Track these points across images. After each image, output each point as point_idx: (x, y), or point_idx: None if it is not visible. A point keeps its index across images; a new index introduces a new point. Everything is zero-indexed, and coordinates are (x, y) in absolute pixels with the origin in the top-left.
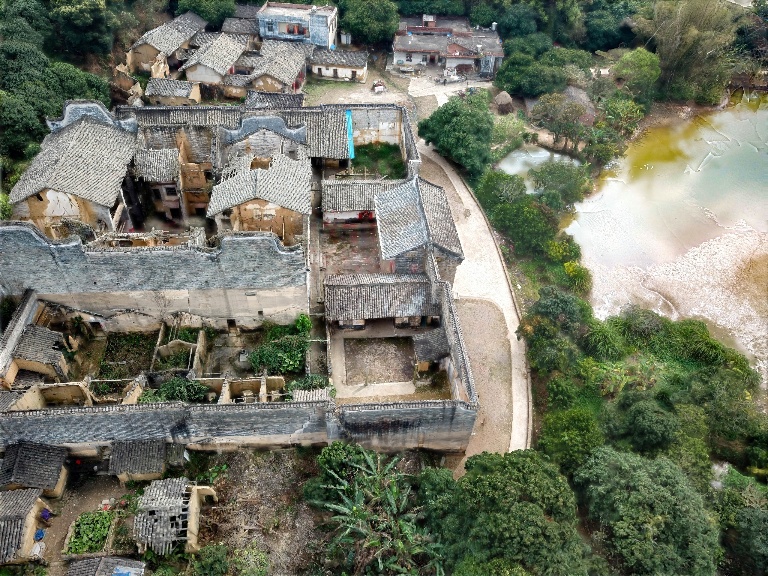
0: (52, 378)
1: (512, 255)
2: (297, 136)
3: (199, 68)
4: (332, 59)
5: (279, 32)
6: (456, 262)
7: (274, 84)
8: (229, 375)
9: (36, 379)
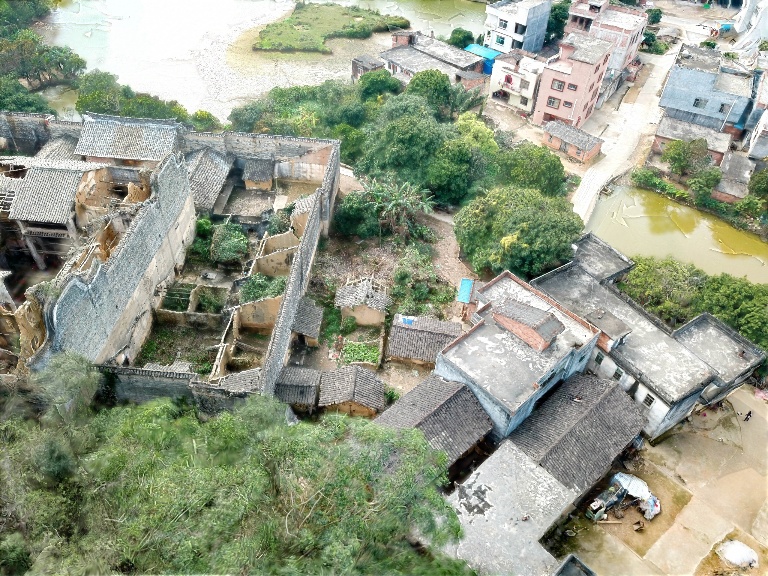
0: None
1: None
2: None
3: None
4: None
5: None
6: None
7: None
8: None
9: None
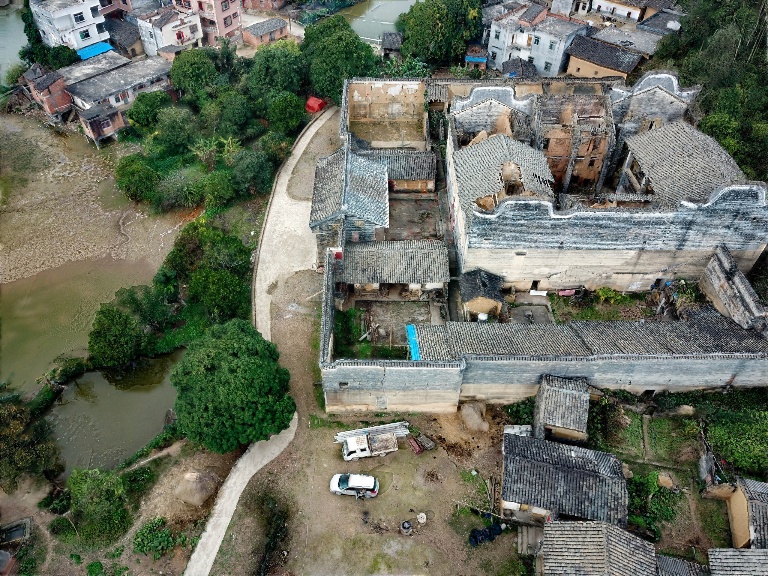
0: None
1: None
2: None
3: None
4: None
5: None
6: None
7: None
8: None
9: None
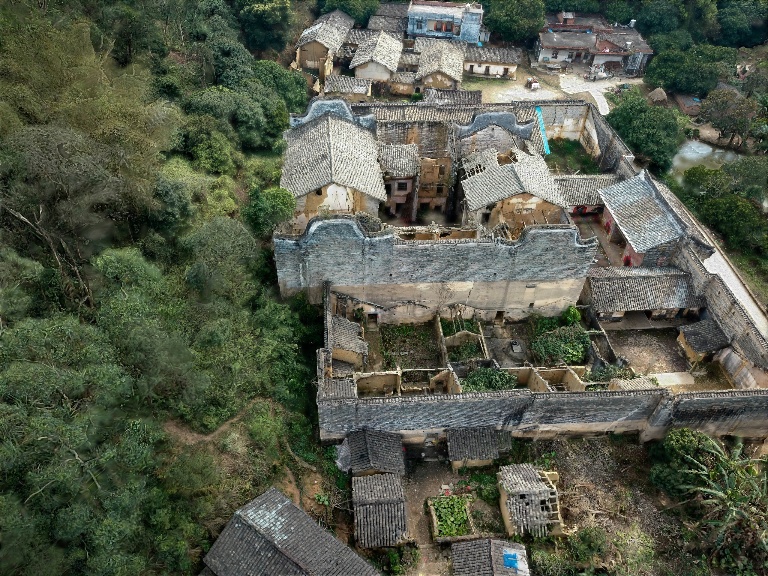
0: (357, 368)
1: (722, 249)
2: (523, 132)
3: (370, 65)
4: (486, 56)
5: (427, 30)
6: (706, 255)
7: (443, 81)
8: (532, 365)
9: (348, 368)
